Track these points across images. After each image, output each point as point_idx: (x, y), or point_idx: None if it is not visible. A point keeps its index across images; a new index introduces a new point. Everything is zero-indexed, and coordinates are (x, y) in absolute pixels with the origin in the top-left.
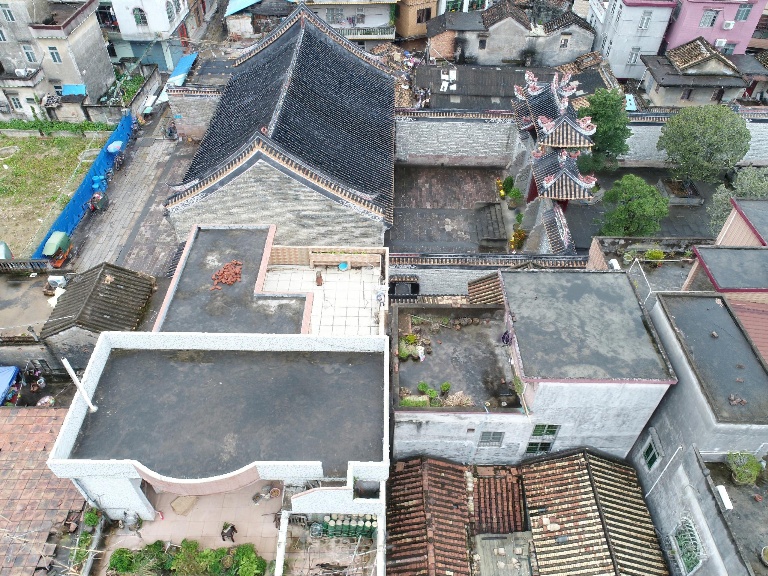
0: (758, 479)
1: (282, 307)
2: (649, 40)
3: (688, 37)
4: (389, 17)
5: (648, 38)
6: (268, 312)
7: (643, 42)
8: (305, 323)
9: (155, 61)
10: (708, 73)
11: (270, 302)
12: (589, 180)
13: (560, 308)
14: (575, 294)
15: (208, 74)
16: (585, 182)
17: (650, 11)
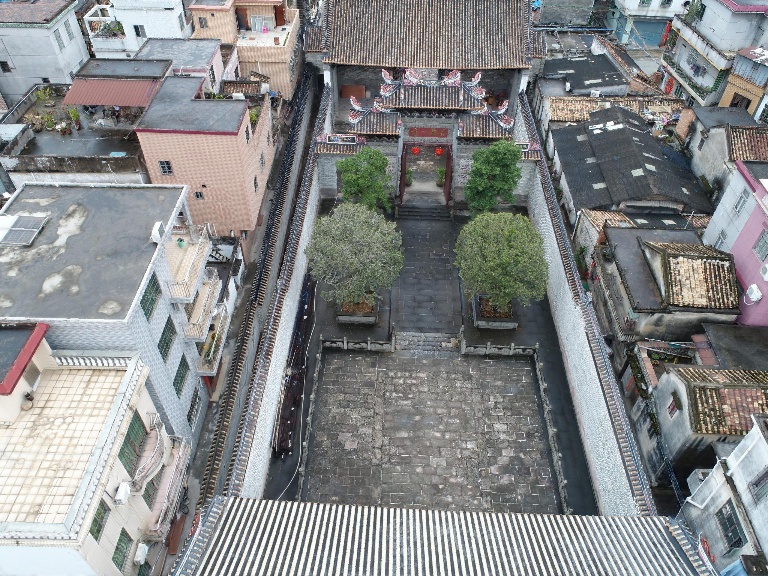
0: (84, 112)
1: (223, 4)
2: (735, 233)
3: (741, 254)
4: (718, 85)
5: (736, 229)
6: (221, 2)
7: (731, 231)
8: (209, 6)
9: (621, 32)
10: (654, 271)
11: (227, 2)
12: (353, 116)
13: (187, 50)
14: (195, 55)
15: (580, 37)
16: (355, 118)
17: (749, 192)
